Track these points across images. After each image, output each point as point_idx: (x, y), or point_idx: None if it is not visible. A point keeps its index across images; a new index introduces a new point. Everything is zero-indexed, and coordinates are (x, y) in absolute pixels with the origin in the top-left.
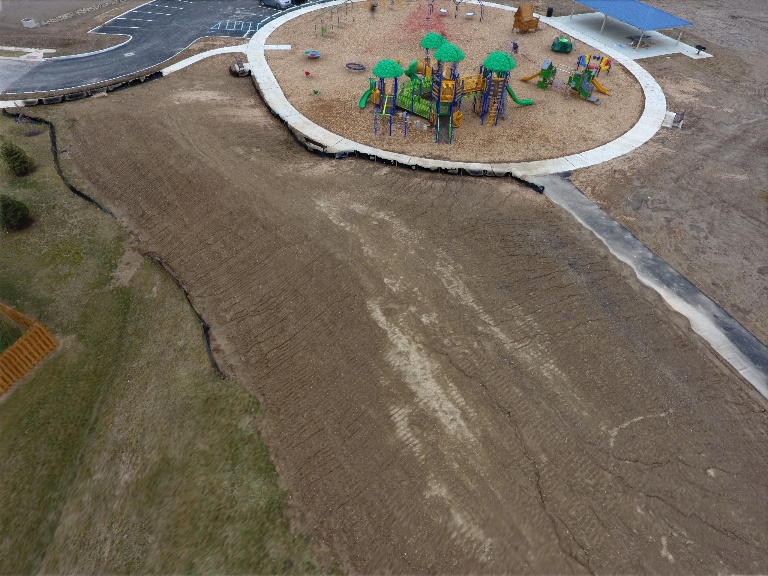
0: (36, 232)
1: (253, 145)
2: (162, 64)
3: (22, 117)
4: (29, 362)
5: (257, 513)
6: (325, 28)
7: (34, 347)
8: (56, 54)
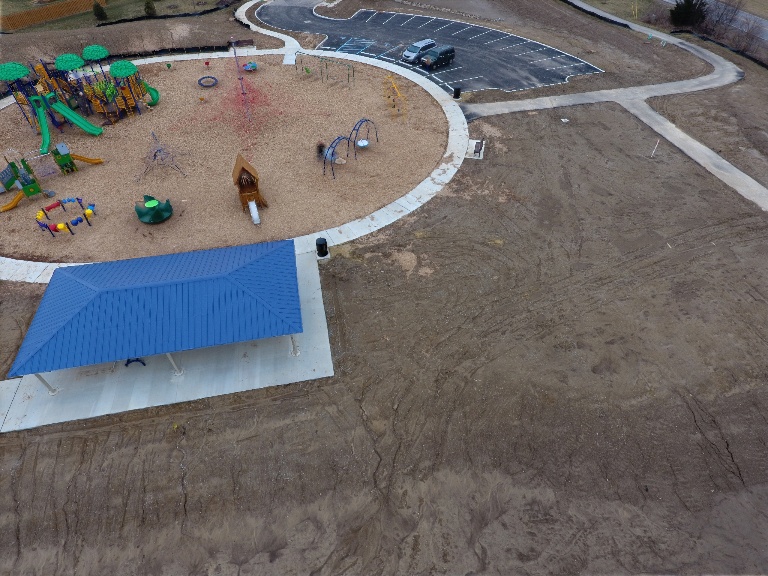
0: (92, 21)
1: (91, 42)
2: (274, 28)
3: (193, 3)
4: (5, 26)
5: None
6: None
7: (5, 23)
8: (321, 7)
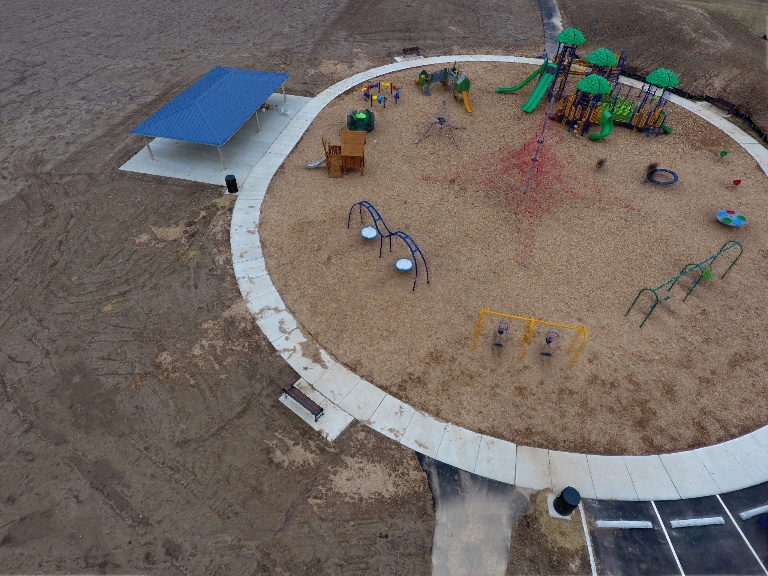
0: None
1: None
2: None
3: None
4: None
5: (742, 21)
6: (709, 268)
7: None
8: None
